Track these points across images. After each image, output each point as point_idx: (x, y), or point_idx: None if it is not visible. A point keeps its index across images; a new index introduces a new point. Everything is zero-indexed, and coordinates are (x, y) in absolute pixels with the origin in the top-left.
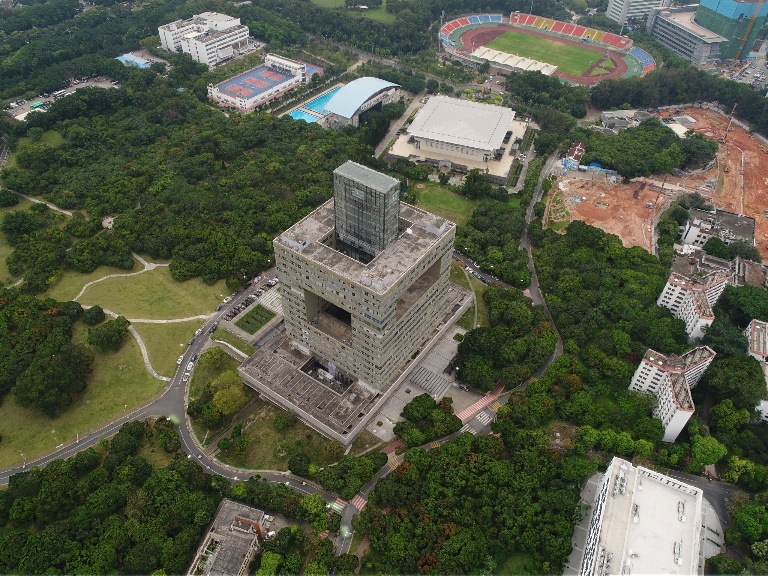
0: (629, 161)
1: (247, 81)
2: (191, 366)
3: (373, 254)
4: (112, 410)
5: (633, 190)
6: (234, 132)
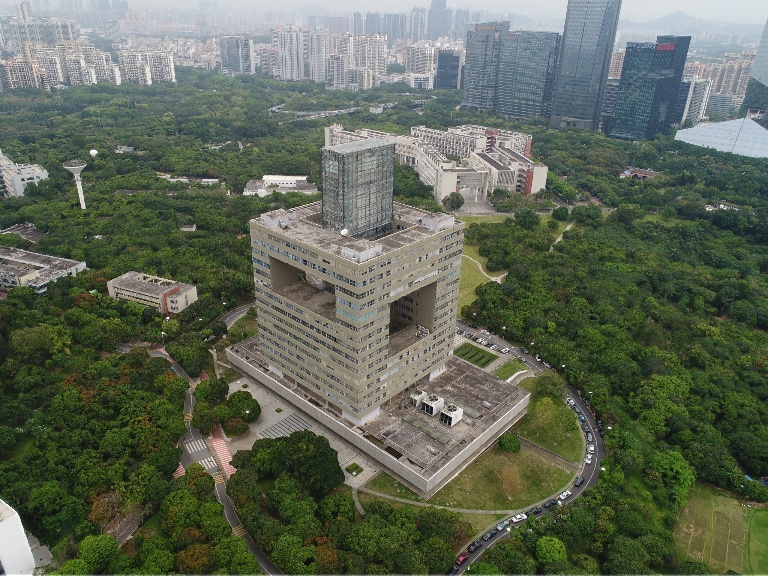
0: None
1: None
2: None
3: None
4: None
5: None
6: None
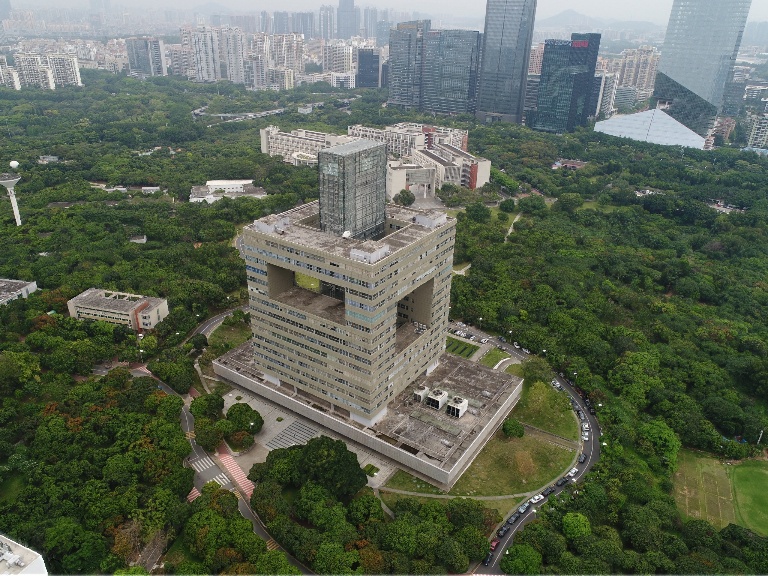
0: None
1: None
2: None
3: None
4: None
5: None
6: (731, 286)
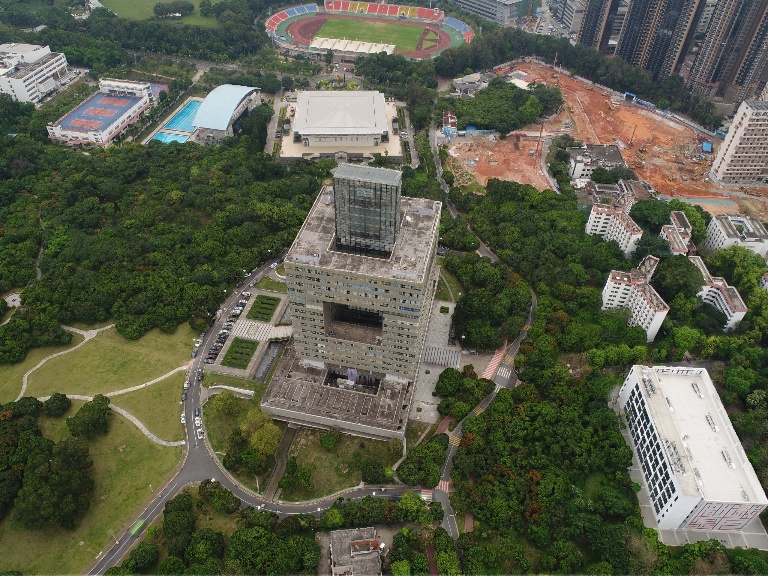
0: (503, 118)
1: (89, 112)
2: (199, 421)
3: (382, 249)
4: (137, 496)
5: (512, 143)
6: (105, 169)
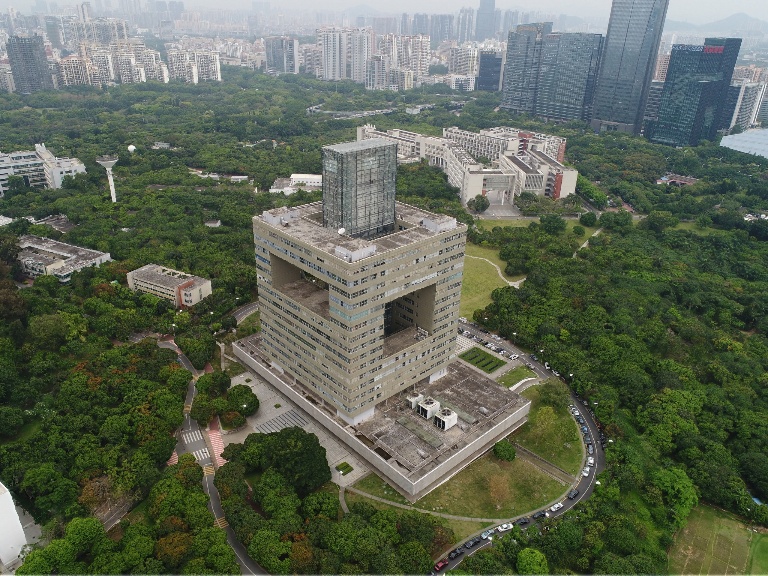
0: None
1: None
2: None
3: None
4: None
5: None
6: None
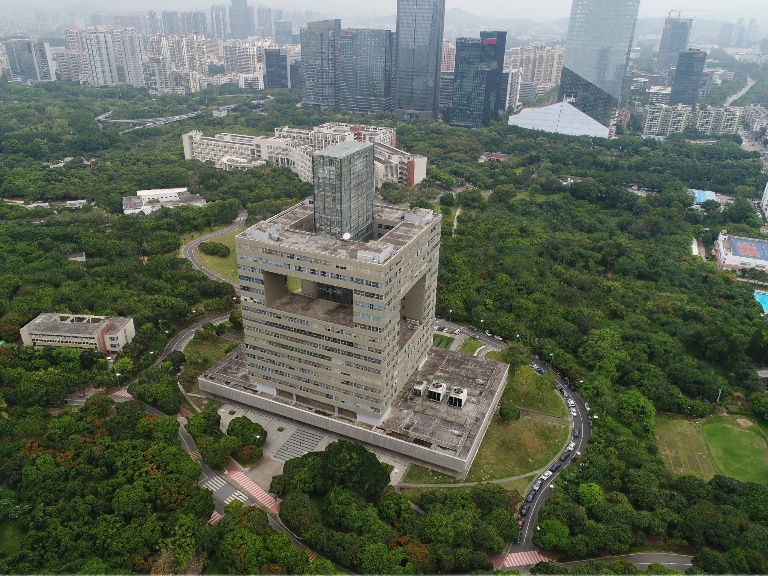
0: None
1: None
2: None
3: None
4: None
5: None
6: (661, 262)
